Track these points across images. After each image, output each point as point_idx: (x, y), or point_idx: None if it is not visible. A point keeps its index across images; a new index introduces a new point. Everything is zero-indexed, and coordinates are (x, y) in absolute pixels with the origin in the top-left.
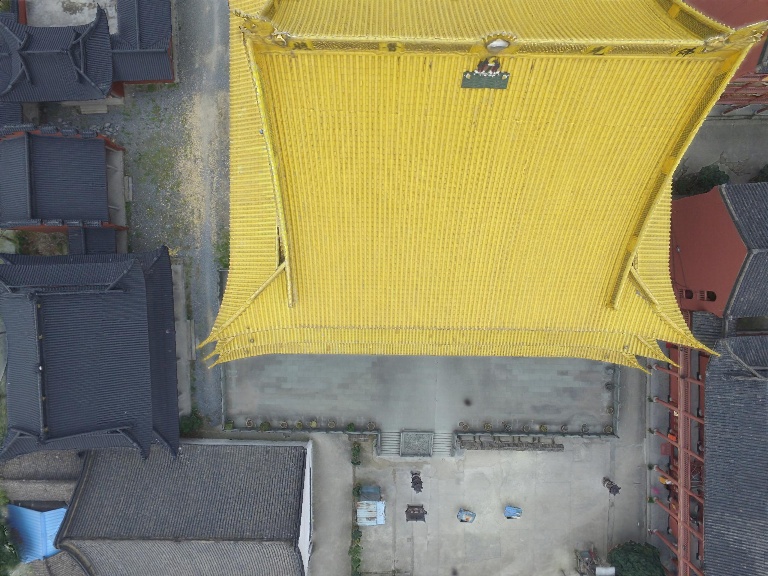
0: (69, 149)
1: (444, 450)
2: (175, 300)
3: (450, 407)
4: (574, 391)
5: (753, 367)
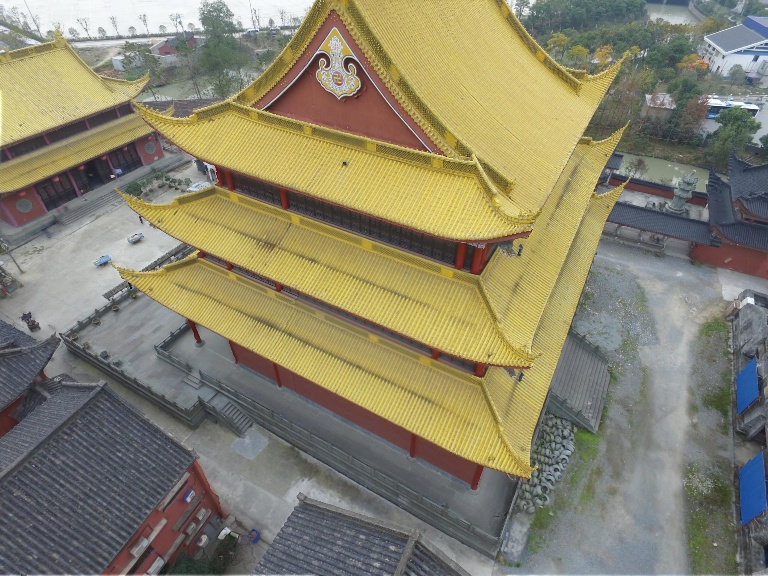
0: None
1: None
2: None
3: None
4: (134, 330)
5: None
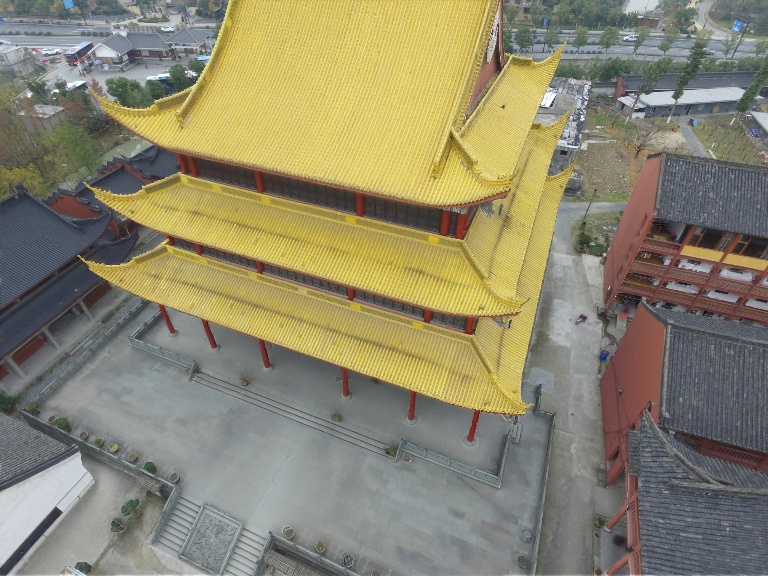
0: (137, 186)
1: (243, 575)
2: (107, 305)
3: (285, 499)
4: (467, 549)
5: (703, 470)
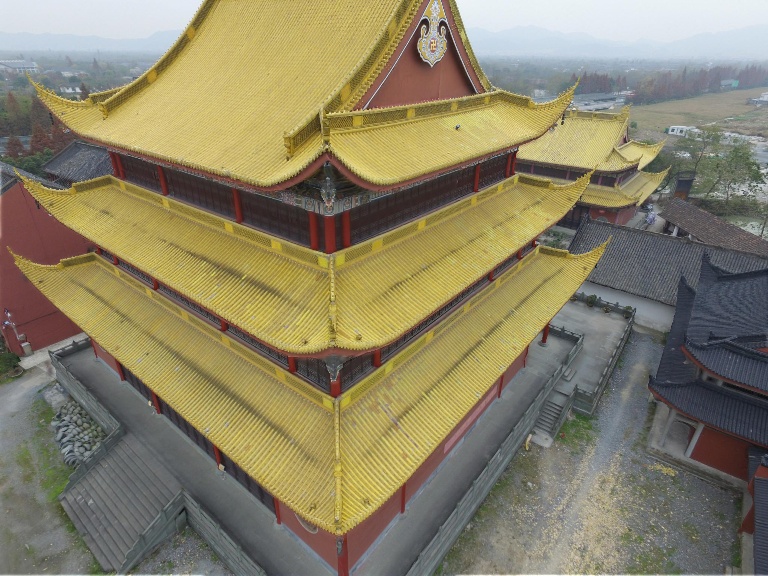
0: None
1: None
2: None
3: None
4: None
5: None
